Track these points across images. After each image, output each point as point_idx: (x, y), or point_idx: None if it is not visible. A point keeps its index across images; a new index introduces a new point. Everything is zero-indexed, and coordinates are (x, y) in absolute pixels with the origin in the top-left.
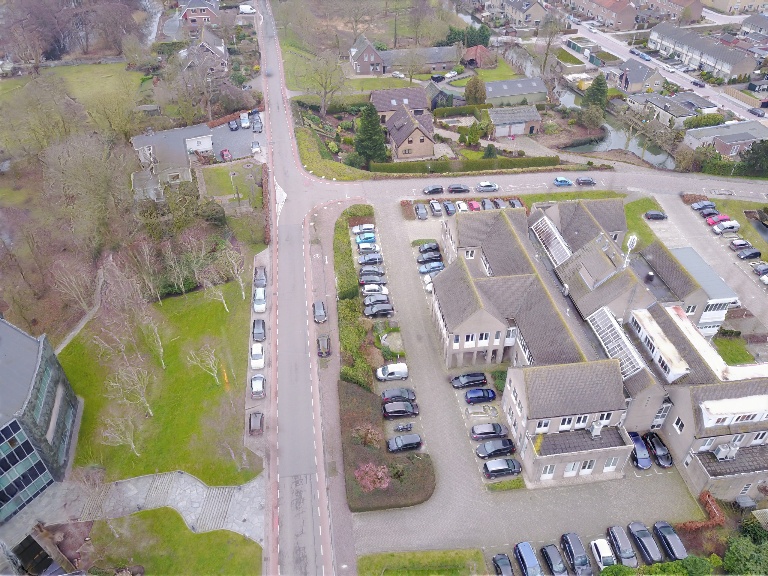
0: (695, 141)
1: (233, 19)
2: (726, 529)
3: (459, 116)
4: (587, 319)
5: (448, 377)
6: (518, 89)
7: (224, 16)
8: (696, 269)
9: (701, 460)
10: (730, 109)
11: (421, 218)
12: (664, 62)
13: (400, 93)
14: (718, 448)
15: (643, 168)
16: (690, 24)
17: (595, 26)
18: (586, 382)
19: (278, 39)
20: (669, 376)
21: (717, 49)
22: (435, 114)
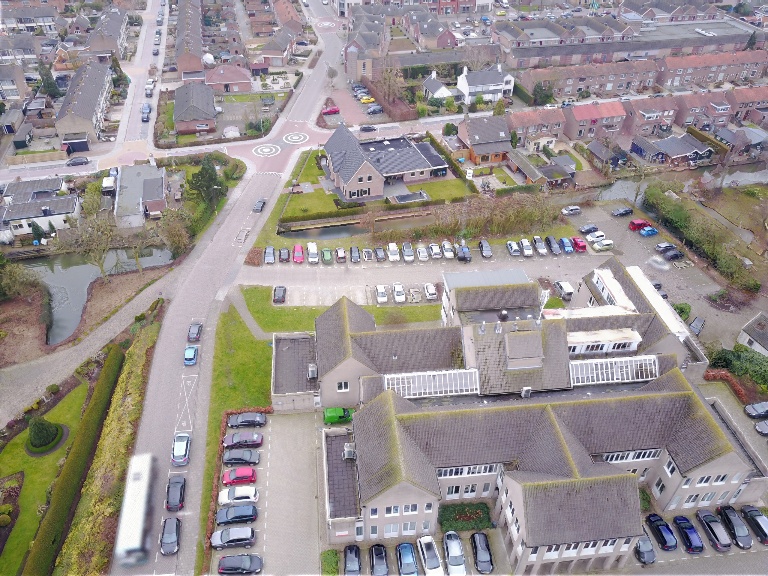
0: (135, 218)
1: None
2: None
3: None
4: (573, 385)
5: (635, 569)
6: None
7: None
8: (482, 281)
9: (684, 363)
10: None
11: (260, 568)
12: None
13: None
14: None
15: (171, 275)
16: None
17: None
18: (704, 403)
19: None
20: (633, 347)
21: None
22: None
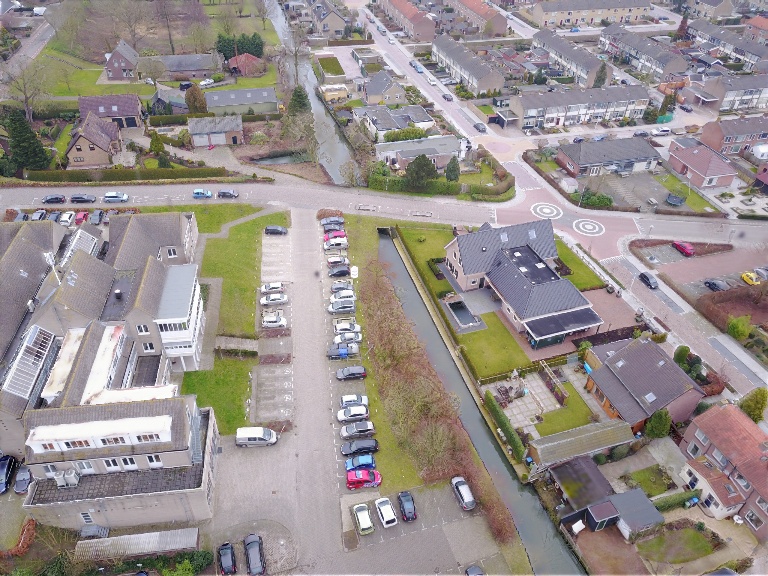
0: (379, 155)
1: (10, 21)
2: (27, 560)
3: (177, 124)
4: (22, 337)
5: None
6: (246, 98)
7: (1, 18)
8: (176, 287)
9: (42, 487)
10: (458, 124)
11: None
12: (433, 75)
13: (109, 100)
14: (54, 475)
15: (306, 181)
16: (494, 37)
17: (398, 37)
18: None
19: (46, 42)
20: None
21: (472, 63)
22: (144, 122)
